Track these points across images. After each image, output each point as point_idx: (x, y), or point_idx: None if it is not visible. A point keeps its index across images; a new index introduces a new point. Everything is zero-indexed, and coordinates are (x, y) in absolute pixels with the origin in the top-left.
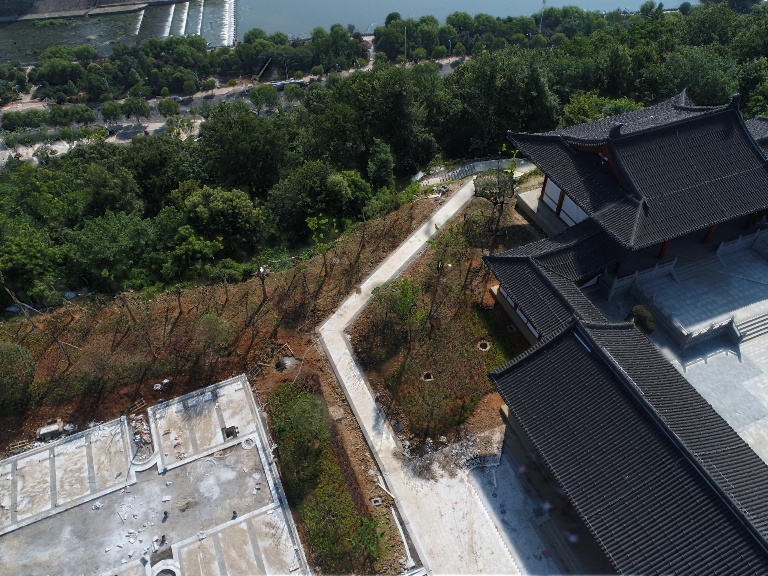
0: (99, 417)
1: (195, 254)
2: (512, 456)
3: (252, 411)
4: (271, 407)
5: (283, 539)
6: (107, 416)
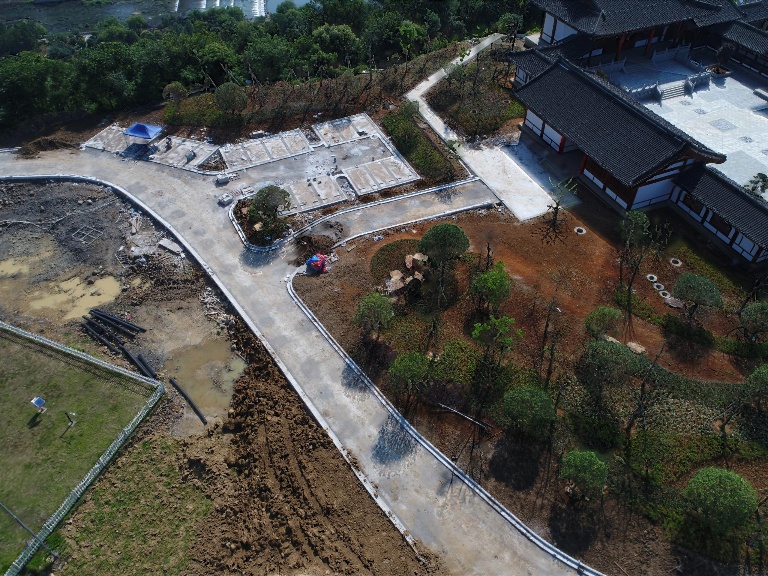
0: (284, 129)
1: (323, 60)
2: (525, 141)
3: (373, 126)
4: (384, 123)
5: (402, 167)
6: (288, 129)
